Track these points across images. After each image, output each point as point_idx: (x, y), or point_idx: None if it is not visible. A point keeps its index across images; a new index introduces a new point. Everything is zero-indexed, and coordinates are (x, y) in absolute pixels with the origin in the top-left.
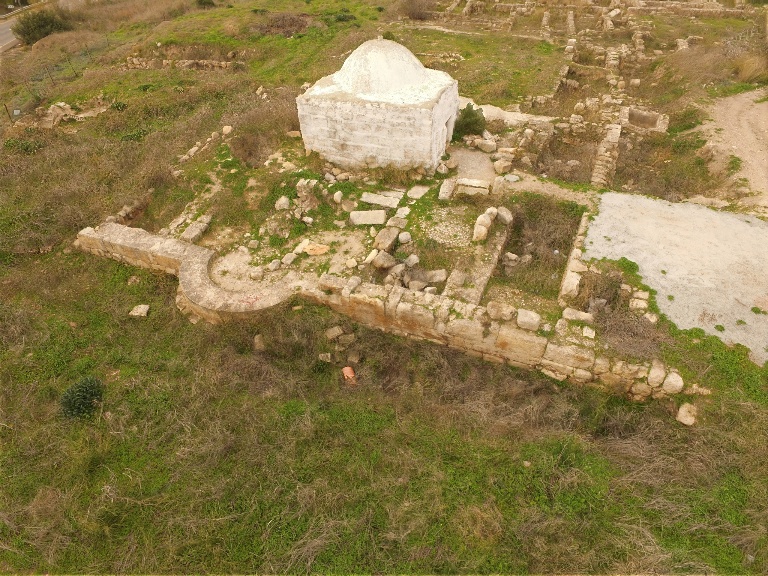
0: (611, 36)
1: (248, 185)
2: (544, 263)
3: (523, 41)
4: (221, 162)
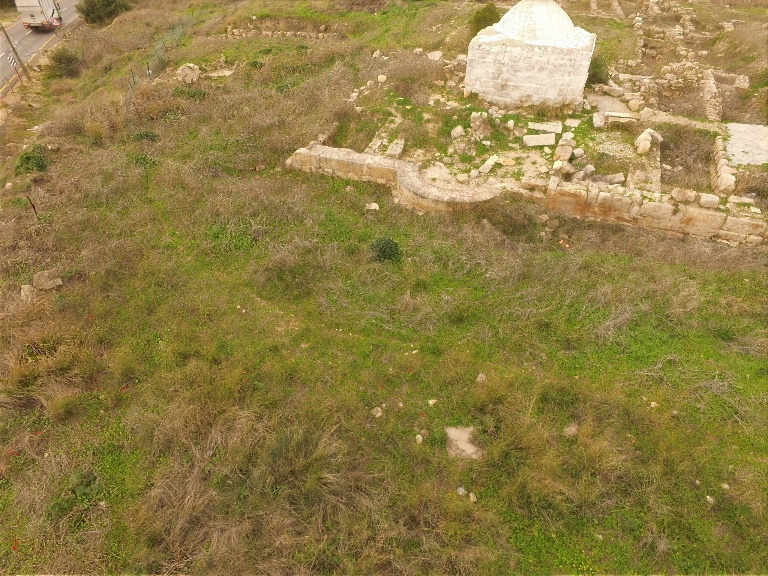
0: (660, 19)
1: (425, 118)
2: (694, 172)
3: (592, 19)
4: (396, 100)
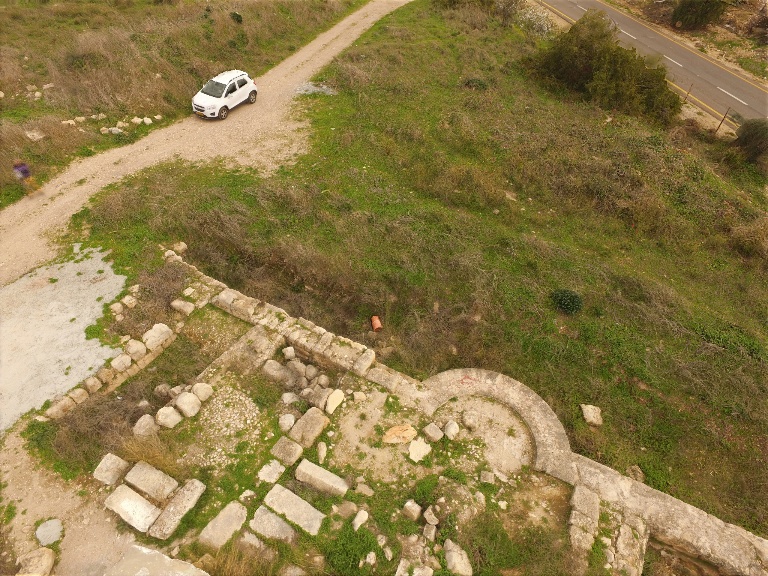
0: None
1: None
2: None
3: None
4: None
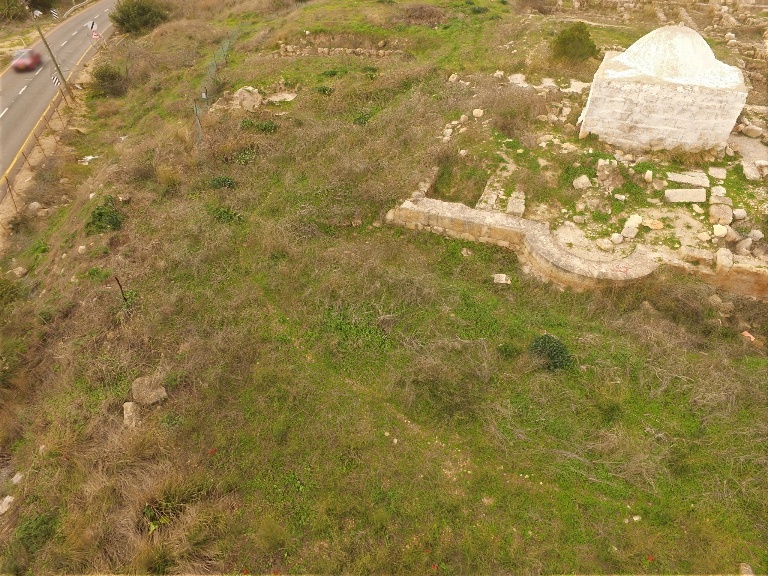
0: (741, 32)
1: (541, 164)
2: None
3: None
4: (504, 142)
